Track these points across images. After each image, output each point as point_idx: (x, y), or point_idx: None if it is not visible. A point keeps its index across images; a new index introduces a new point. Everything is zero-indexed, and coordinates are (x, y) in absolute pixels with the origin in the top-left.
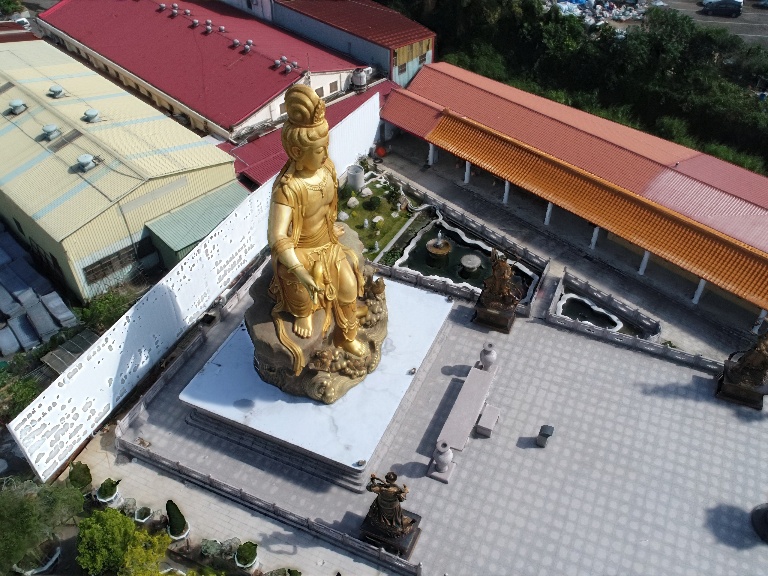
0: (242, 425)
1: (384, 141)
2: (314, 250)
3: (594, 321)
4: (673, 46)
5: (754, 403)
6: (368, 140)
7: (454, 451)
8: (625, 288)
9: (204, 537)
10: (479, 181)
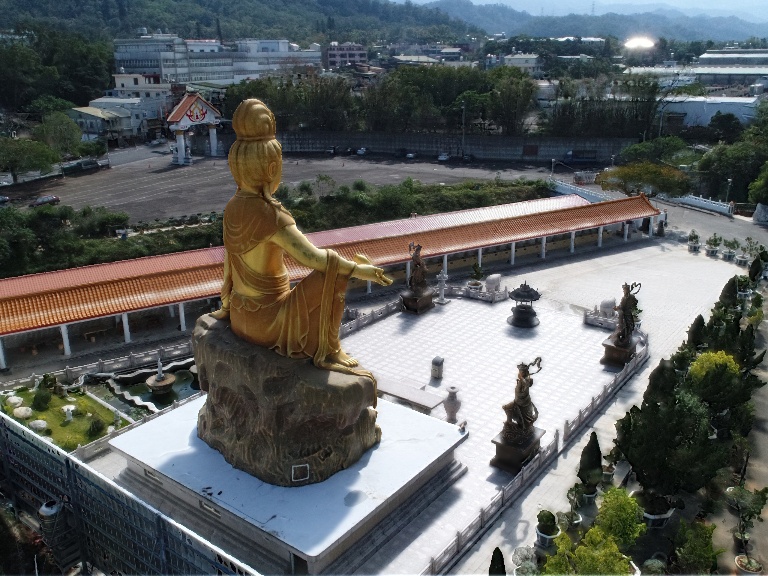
0: (384, 504)
1: None
2: None
3: None
4: (24, 230)
5: (431, 304)
6: None
7: (433, 415)
8: None
9: None
10: (76, 347)
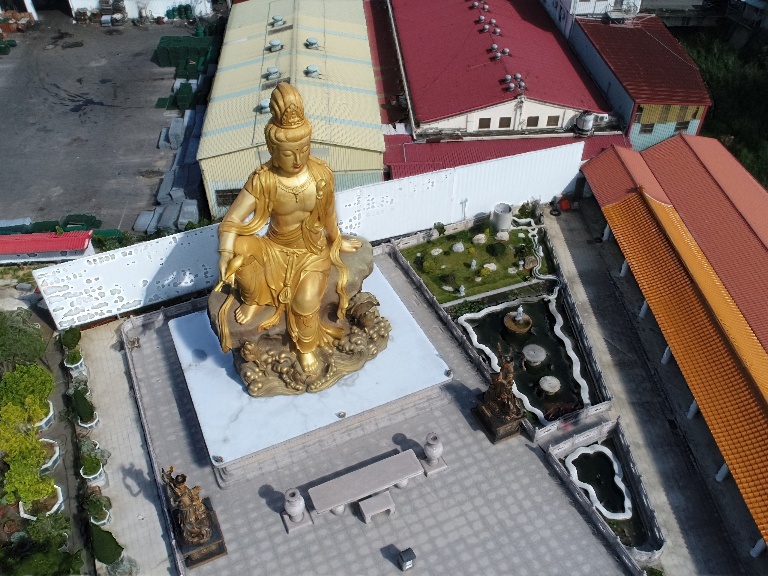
0: (183, 370)
1: (581, 196)
2: (284, 249)
3: (605, 492)
4: None
5: None
6: (554, 187)
7: None
8: (679, 481)
9: (101, 437)
10: None
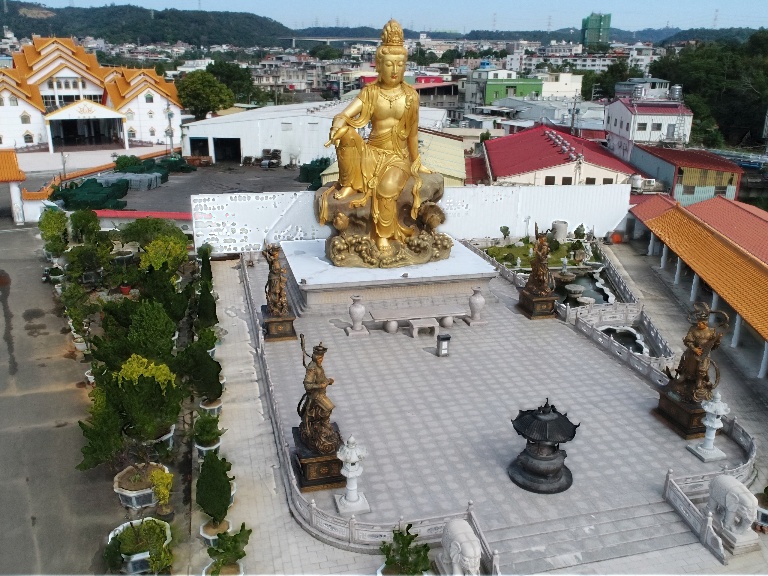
0: None
1: (632, 238)
2: (377, 149)
3: None
4: None
5: (681, 428)
6: (607, 224)
7: (380, 331)
8: None
9: None
10: (675, 270)
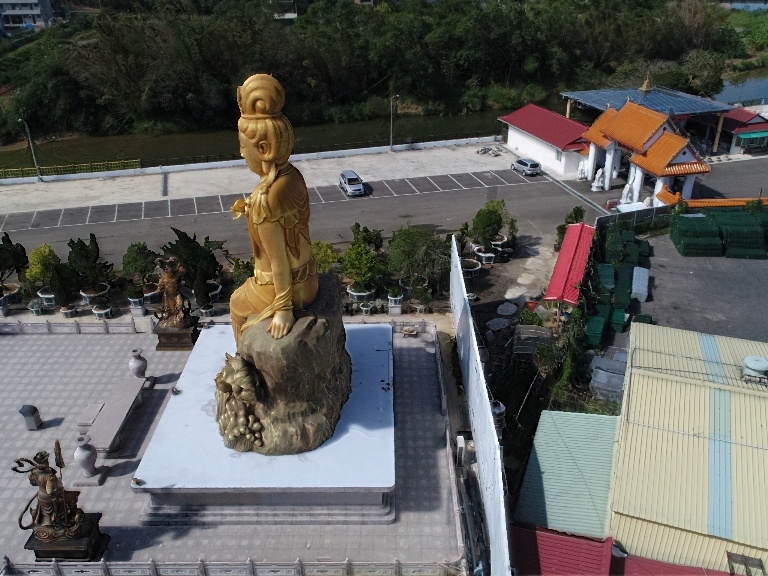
0: None
1: None
2: None
3: None
4: None
5: None
6: None
7: None
8: None
9: None
10: None
